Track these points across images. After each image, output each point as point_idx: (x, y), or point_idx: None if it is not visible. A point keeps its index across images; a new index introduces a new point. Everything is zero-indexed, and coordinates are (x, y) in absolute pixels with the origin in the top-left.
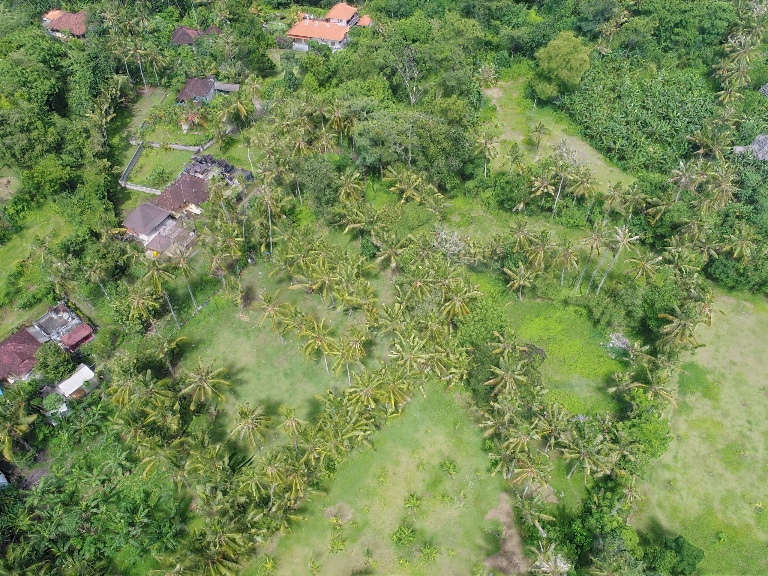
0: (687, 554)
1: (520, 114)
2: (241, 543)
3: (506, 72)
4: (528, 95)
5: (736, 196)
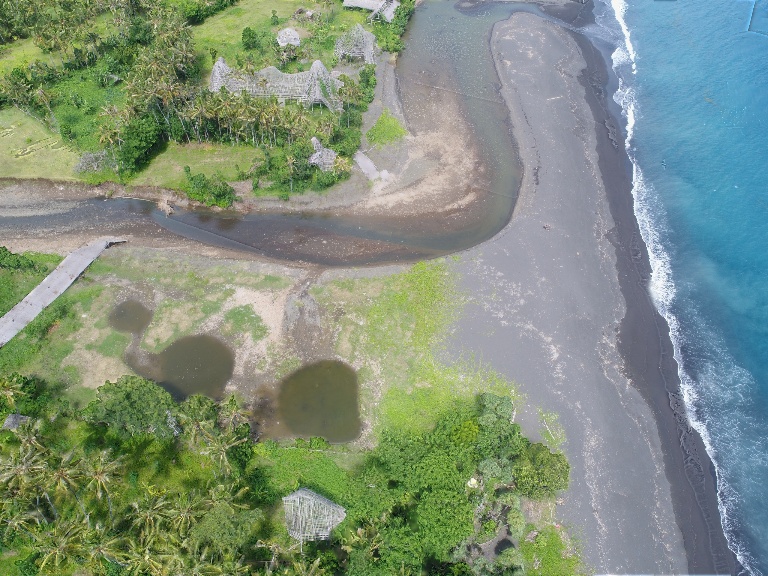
0: None
1: None
2: (1, 19)
3: None
4: None
5: None
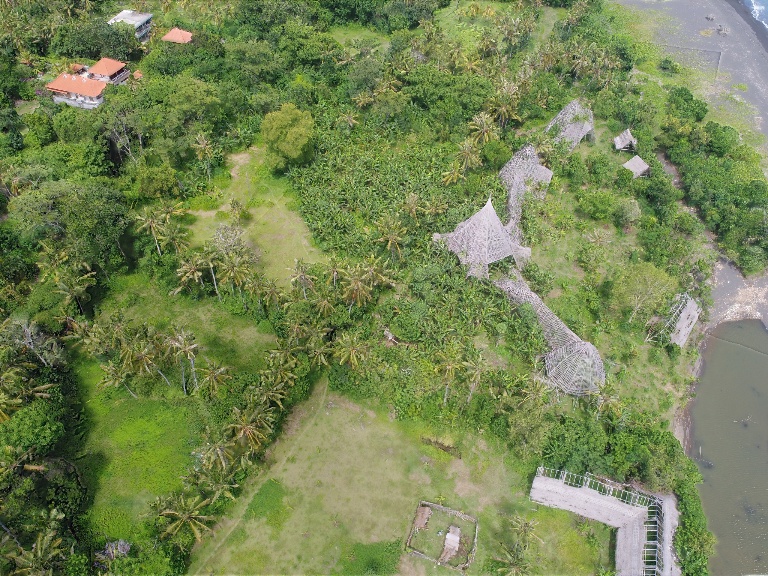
0: None
1: (253, 184)
2: None
3: (261, 137)
4: None
5: None
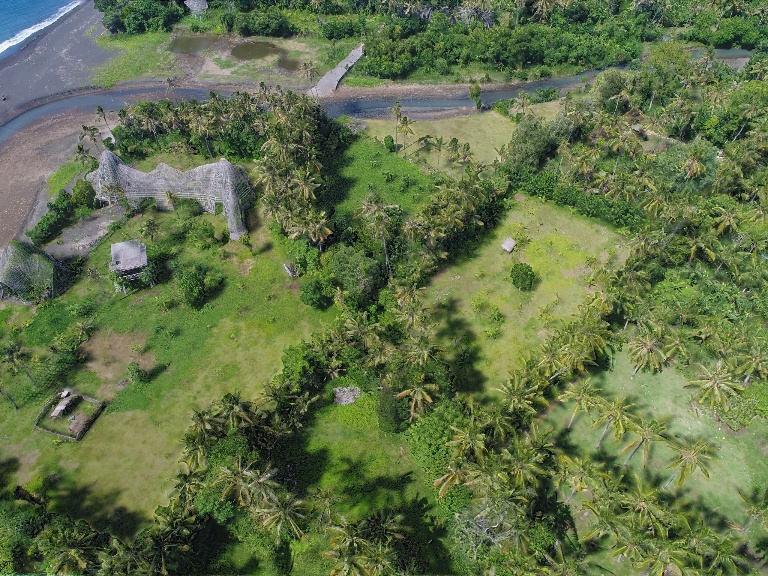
0: None
1: None
2: (611, 280)
3: None
4: None
5: None
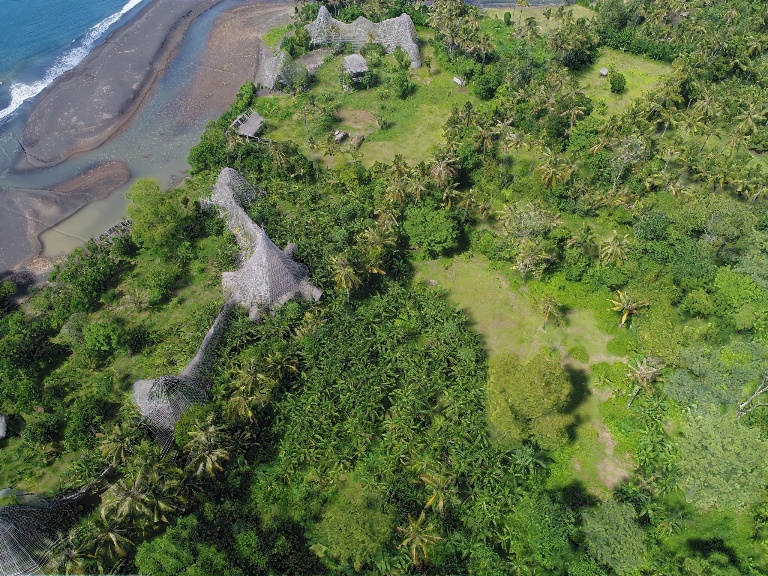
0: None
1: (566, 411)
2: (679, 77)
3: None
4: None
5: None
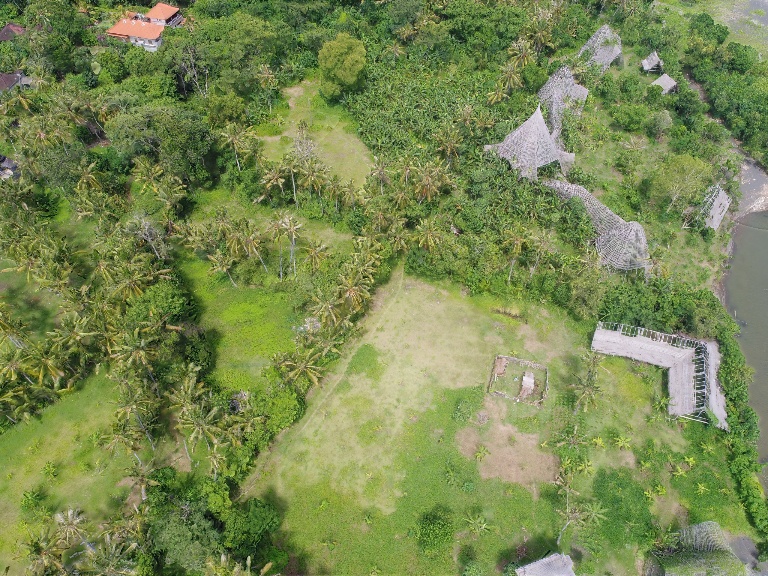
0: (255, 515)
1: (310, 112)
2: None
3: (312, 72)
4: (321, 94)
5: (470, 191)
